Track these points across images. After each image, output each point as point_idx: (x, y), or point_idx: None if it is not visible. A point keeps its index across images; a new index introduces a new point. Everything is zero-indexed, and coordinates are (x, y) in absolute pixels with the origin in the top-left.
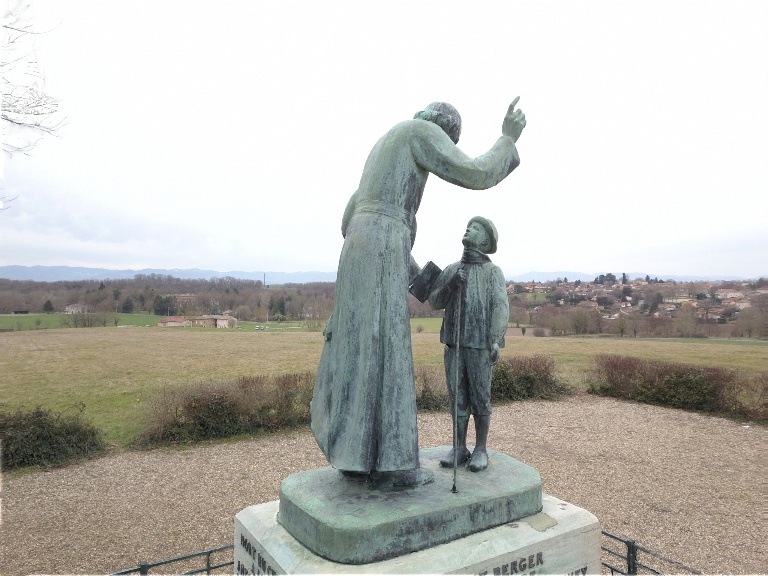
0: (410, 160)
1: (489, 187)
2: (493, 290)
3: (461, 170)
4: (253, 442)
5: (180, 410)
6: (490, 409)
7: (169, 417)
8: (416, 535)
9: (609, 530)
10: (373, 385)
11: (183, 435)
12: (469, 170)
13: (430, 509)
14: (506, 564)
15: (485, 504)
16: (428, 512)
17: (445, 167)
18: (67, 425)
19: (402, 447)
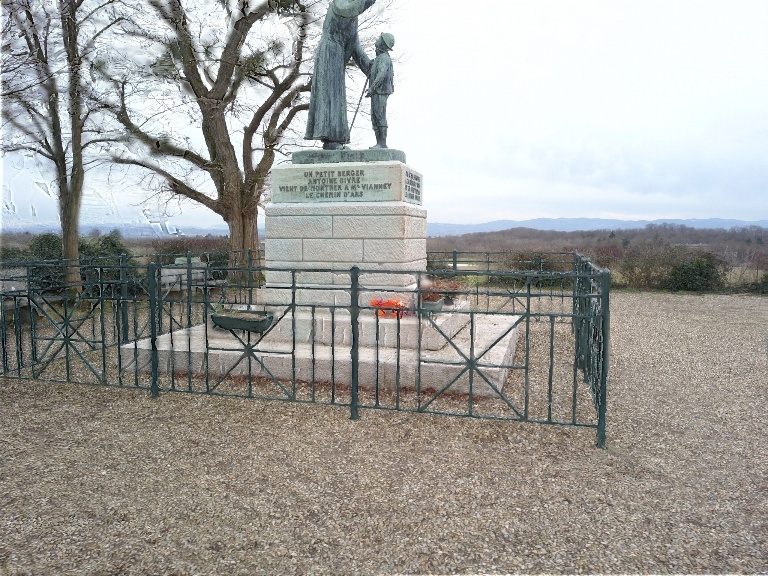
0: (332, 13)
1: (354, 15)
2: (378, 65)
3: (341, 11)
4: (560, 291)
5: (511, 263)
6: (383, 124)
7: (506, 268)
8: (316, 158)
9: (763, 342)
10: (312, 105)
11: (511, 281)
12: (343, 10)
13: (324, 150)
14: (344, 170)
15: (349, 152)
16: (322, 151)
17: (338, 11)
18: (437, 263)
19: (319, 128)
